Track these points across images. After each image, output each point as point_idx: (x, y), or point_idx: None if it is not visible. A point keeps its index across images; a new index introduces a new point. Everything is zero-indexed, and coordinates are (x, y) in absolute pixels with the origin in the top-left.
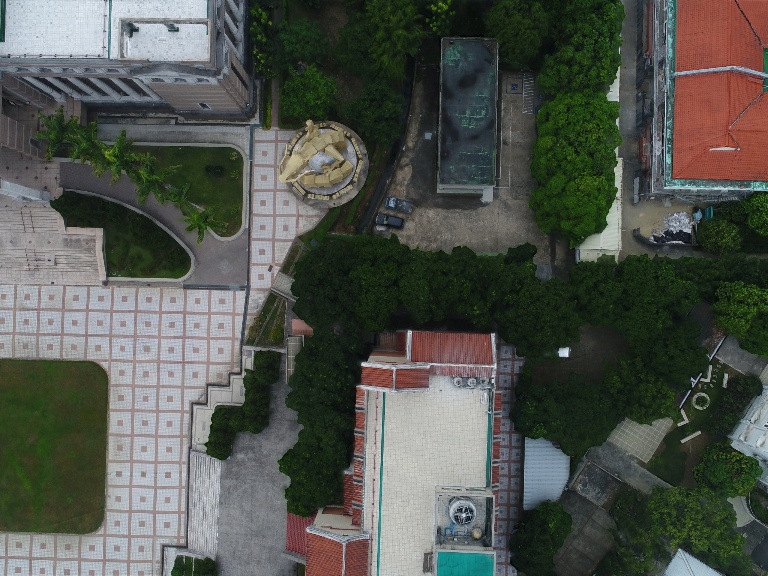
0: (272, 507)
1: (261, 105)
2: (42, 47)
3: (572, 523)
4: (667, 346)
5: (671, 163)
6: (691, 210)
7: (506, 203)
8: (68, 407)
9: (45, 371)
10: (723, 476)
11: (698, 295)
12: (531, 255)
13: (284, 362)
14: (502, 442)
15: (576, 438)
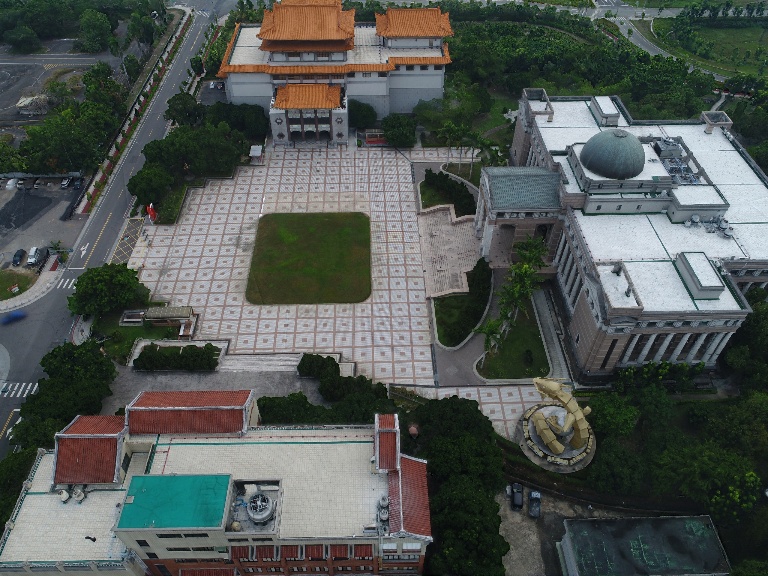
0: None
1: (591, 389)
2: (587, 232)
3: None
4: None
5: None
6: None
7: None
8: (338, 282)
9: (363, 269)
10: None
11: None
12: None
13: None
14: None
15: None
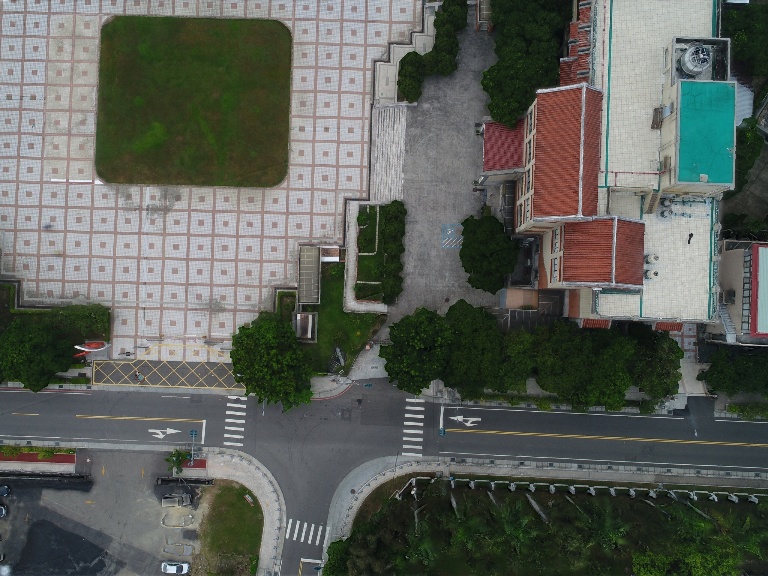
0: (457, 154)
1: None
2: None
3: None
4: None
5: None
6: None
7: None
8: (252, 64)
9: (229, 29)
10: None
11: None
12: None
13: (469, 15)
14: None
15: None
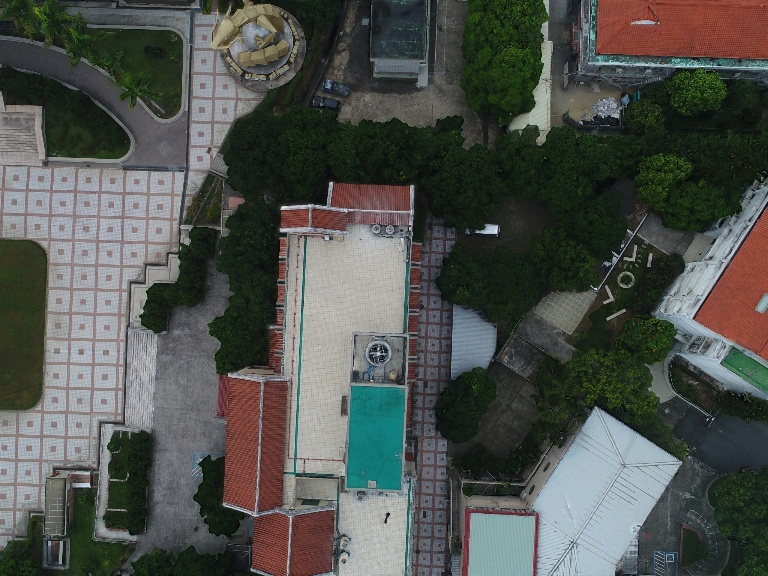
0: (207, 382)
1: None
2: None
3: (500, 398)
4: (587, 213)
5: (595, 39)
6: (619, 96)
7: (441, 88)
8: (7, 285)
9: None
10: (639, 337)
11: (622, 171)
12: (458, 126)
13: None
14: (433, 319)
15: (500, 304)
